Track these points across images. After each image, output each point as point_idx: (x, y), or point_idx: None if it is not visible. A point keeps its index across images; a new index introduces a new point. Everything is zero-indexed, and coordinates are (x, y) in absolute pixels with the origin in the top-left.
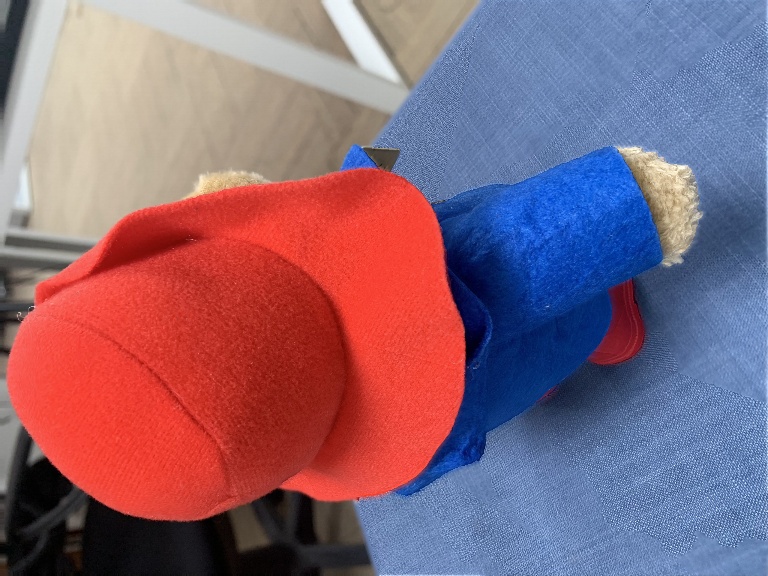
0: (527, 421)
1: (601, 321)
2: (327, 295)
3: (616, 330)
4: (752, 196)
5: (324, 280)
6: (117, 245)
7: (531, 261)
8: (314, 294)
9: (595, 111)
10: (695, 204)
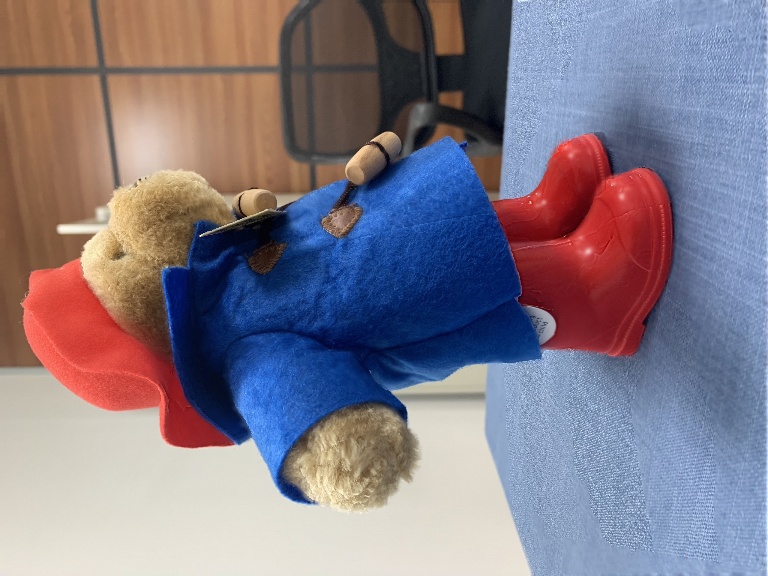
0: None
1: None
2: None
3: (581, 345)
4: (757, 392)
5: None
6: None
7: None
8: None
9: (760, 53)
10: None
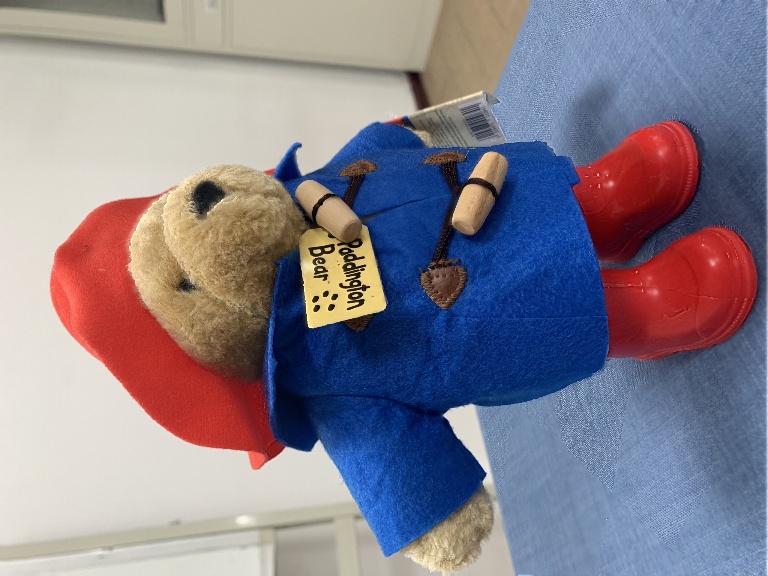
0: None
1: None
2: None
3: None
4: (765, 503)
5: None
6: None
7: None
8: None
9: None
10: None
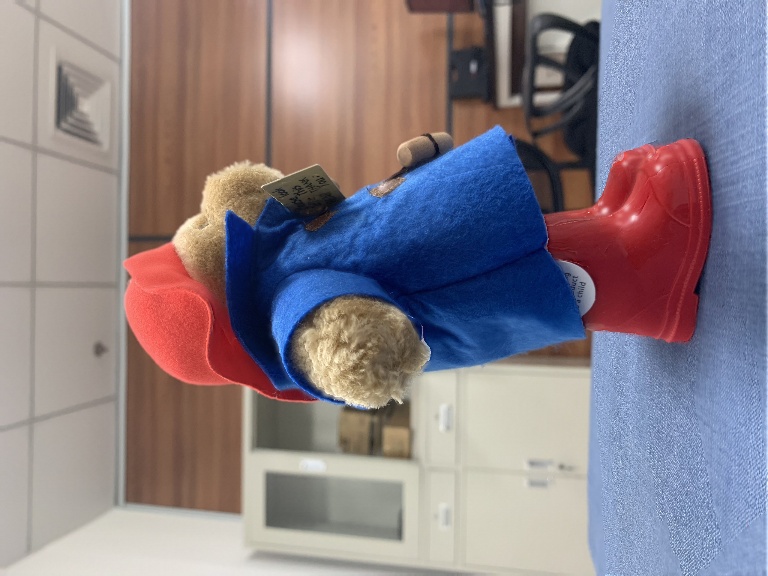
0: None
1: (557, 329)
2: None
3: (631, 322)
4: None
5: None
6: None
7: None
8: None
9: None
10: None
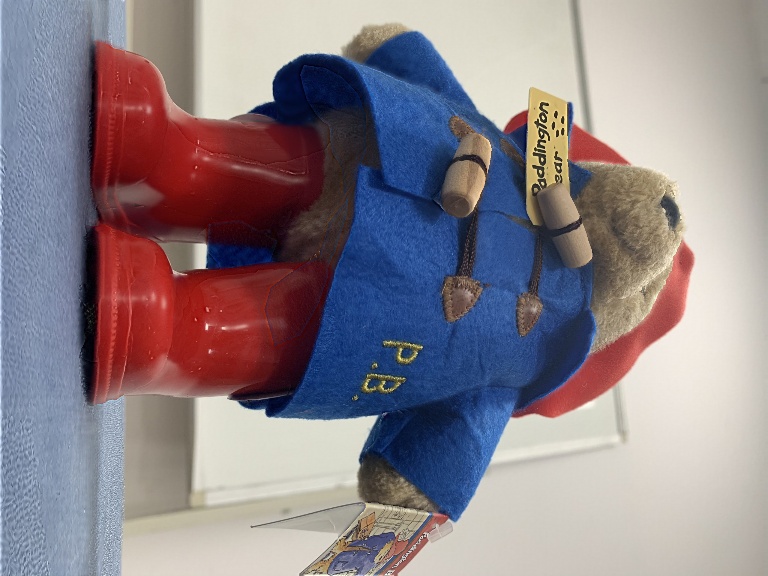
0: None
1: None
2: None
3: None
4: None
5: None
6: None
7: None
8: None
9: None
10: None
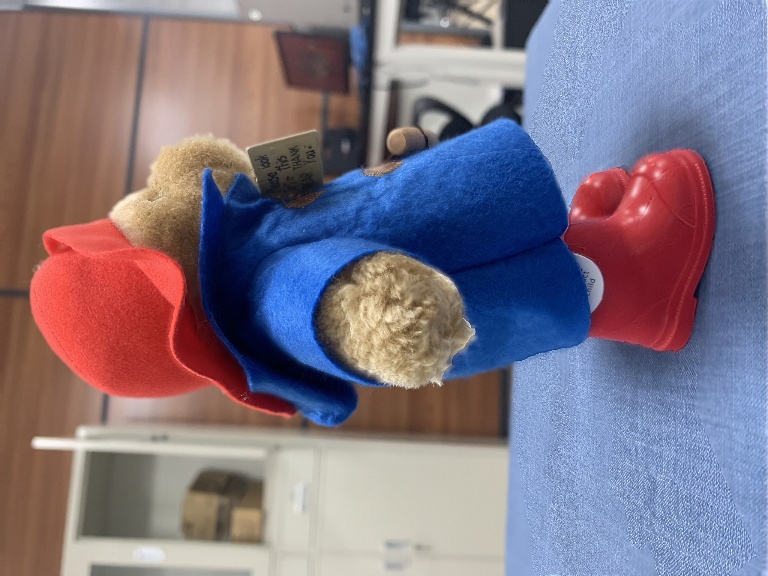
0: (599, 343)
1: (564, 329)
2: (171, 303)
3: (630, 327)
4: None
5: (165, 294)
6: (52, 244)
7: (282, 339)
8: (159, 303)
9: None
10: (400, 360)
